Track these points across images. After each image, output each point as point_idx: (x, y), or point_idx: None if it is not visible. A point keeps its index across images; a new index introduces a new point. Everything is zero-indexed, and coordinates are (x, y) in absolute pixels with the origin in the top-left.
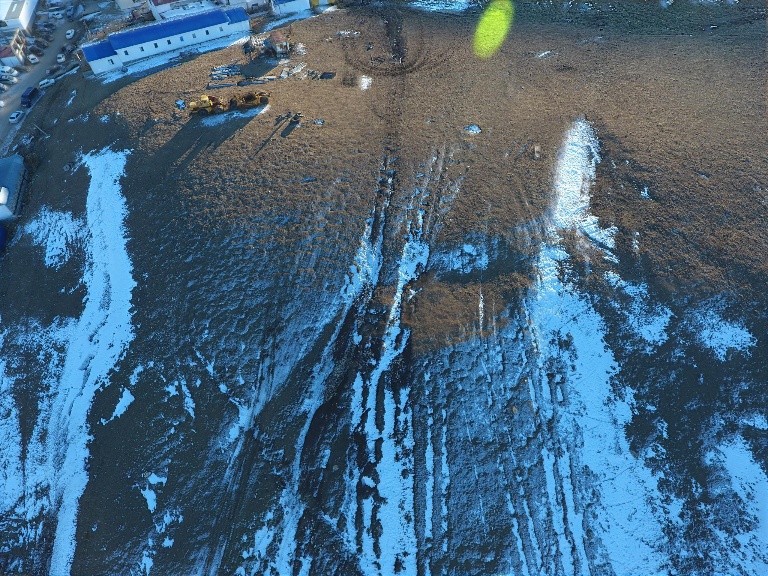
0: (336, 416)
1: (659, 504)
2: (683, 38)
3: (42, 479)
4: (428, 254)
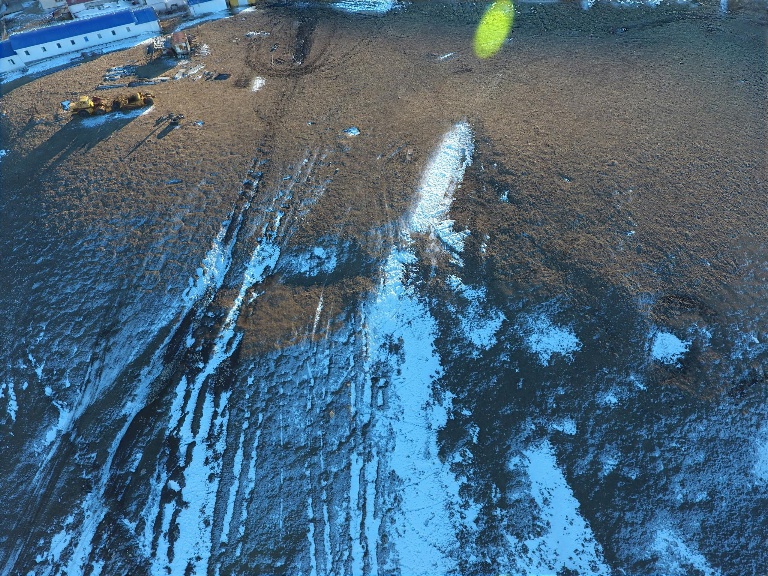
0: (154, 419)
1: (457, 509)
2: (590, 40)
3: None
4: (278, 257)
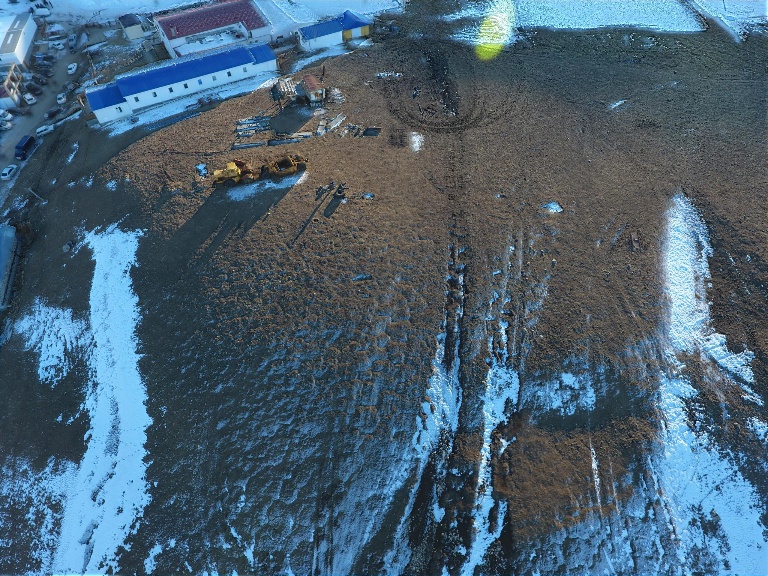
0: None
1: None
2: None
3: None
4: (518, 386)
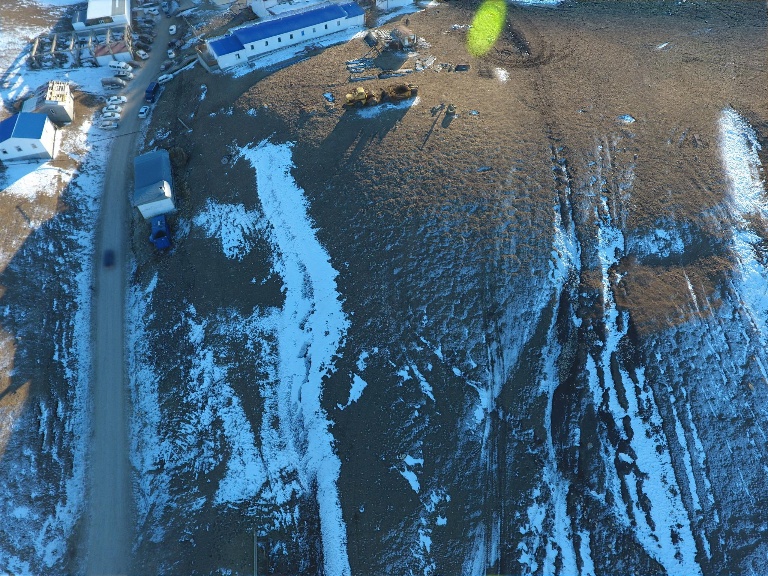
0: (577, 396)
1: None
2: None
3: (286, 464)
4: (623, 239)
